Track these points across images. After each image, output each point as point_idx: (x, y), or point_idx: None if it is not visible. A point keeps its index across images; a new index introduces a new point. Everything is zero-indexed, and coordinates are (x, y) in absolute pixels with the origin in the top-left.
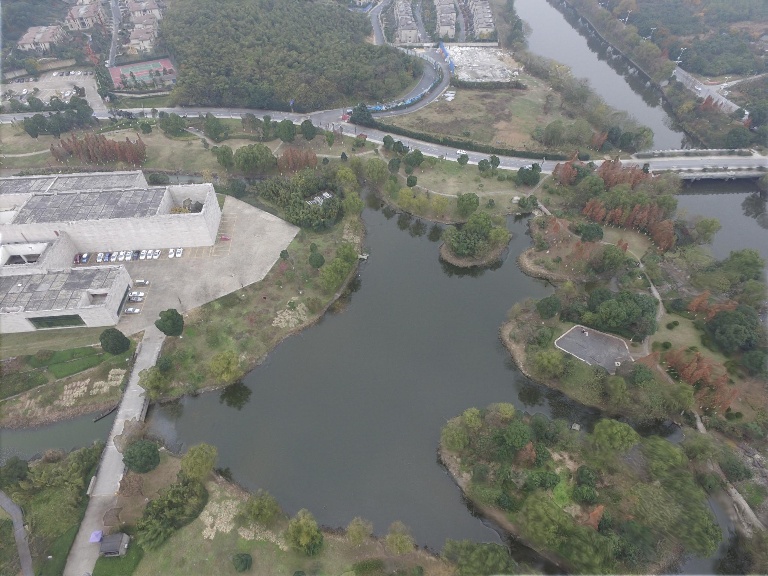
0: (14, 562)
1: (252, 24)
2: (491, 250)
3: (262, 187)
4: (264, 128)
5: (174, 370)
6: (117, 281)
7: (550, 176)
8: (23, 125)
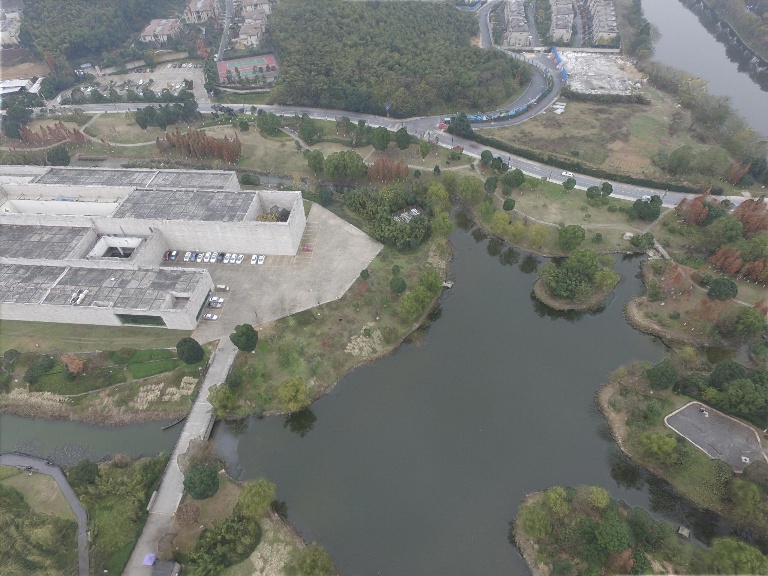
0: (74, 569)
1: (357, 23)
2: (594, 293)
3: (349, 197)
4: (358, 133)
5: (243, 387)
6: (200, 286)
7: (672, 211)
8: (135, 116)
